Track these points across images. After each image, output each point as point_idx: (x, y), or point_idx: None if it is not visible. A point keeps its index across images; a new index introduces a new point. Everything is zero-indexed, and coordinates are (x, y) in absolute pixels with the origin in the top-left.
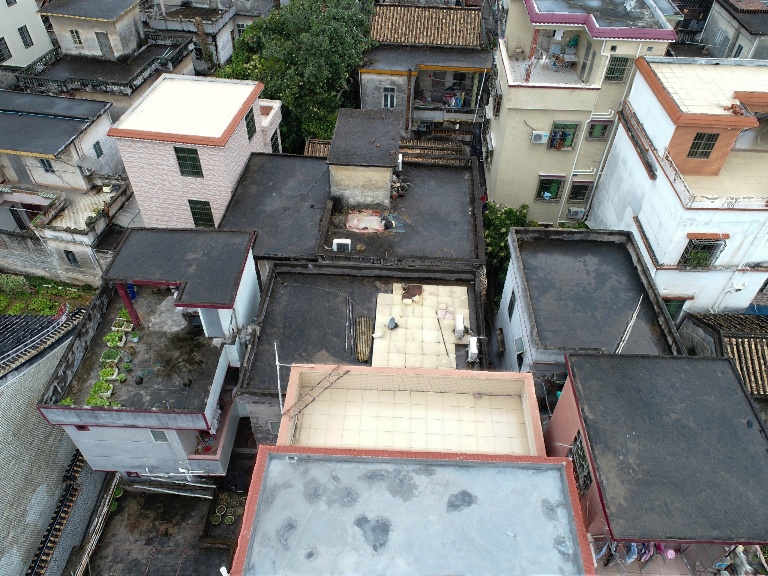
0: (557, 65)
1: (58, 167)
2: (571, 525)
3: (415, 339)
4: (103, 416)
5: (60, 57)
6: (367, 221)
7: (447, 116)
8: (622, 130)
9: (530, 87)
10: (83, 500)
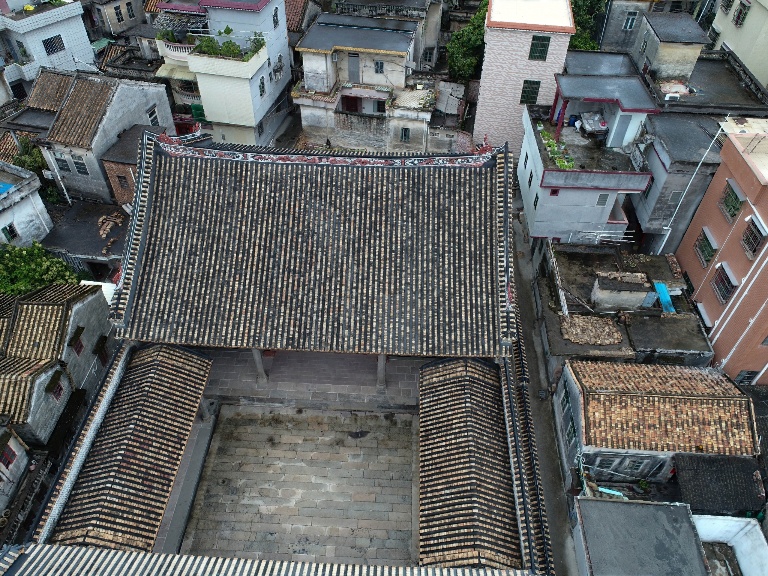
0: None
1: (389, 68)
2: None
3: None
4: (583, 178)
5: None
6: (677, 87)
7: None
8: None
9: None
10: None
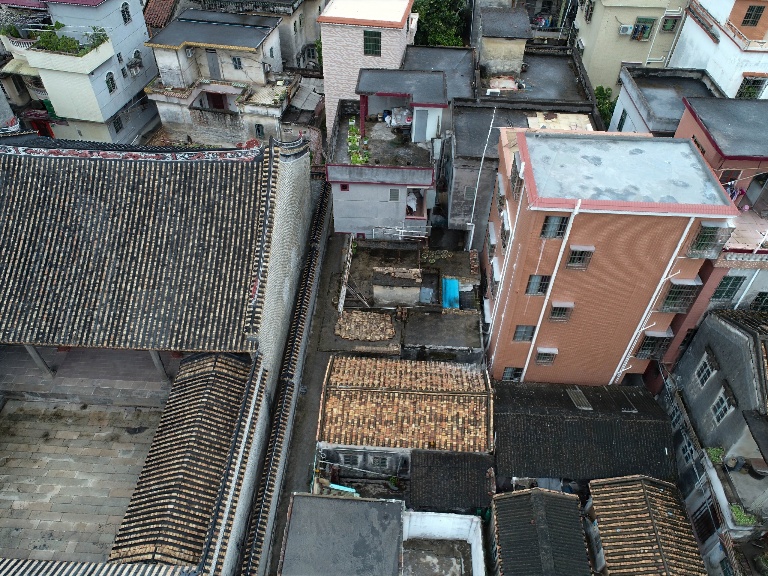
0: None
1: (246, 64)
2: (699, 158)
3: None
4: (366, 173)
5: None
6: (505, 83)
7: (538, 34)
8: (689, 20)
9: None
10: (317, 263)
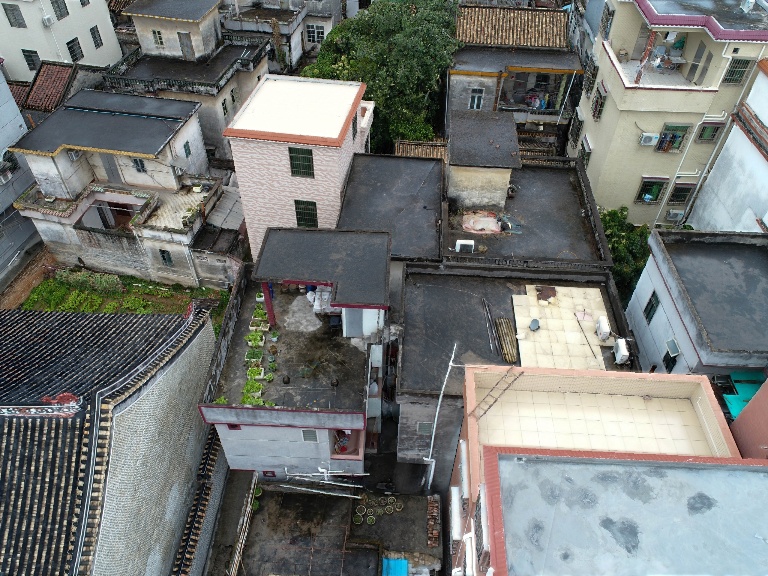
0: (662, 67)
1: (151, 167)
2: None
3: (559, 341)
4: (262, 415)
5: (140, 57)
6: (484, 222)
7: (531, 118)
8: (738, 132)
9: (647, 89)
10: (212, 499)
